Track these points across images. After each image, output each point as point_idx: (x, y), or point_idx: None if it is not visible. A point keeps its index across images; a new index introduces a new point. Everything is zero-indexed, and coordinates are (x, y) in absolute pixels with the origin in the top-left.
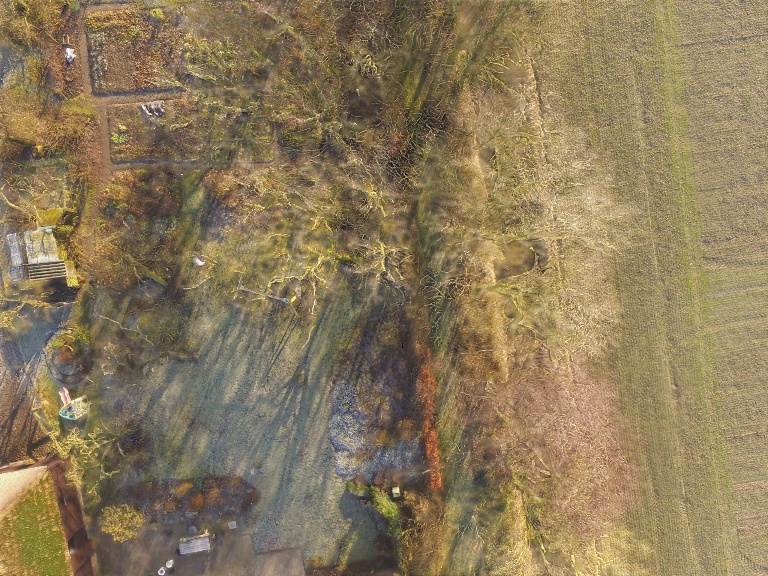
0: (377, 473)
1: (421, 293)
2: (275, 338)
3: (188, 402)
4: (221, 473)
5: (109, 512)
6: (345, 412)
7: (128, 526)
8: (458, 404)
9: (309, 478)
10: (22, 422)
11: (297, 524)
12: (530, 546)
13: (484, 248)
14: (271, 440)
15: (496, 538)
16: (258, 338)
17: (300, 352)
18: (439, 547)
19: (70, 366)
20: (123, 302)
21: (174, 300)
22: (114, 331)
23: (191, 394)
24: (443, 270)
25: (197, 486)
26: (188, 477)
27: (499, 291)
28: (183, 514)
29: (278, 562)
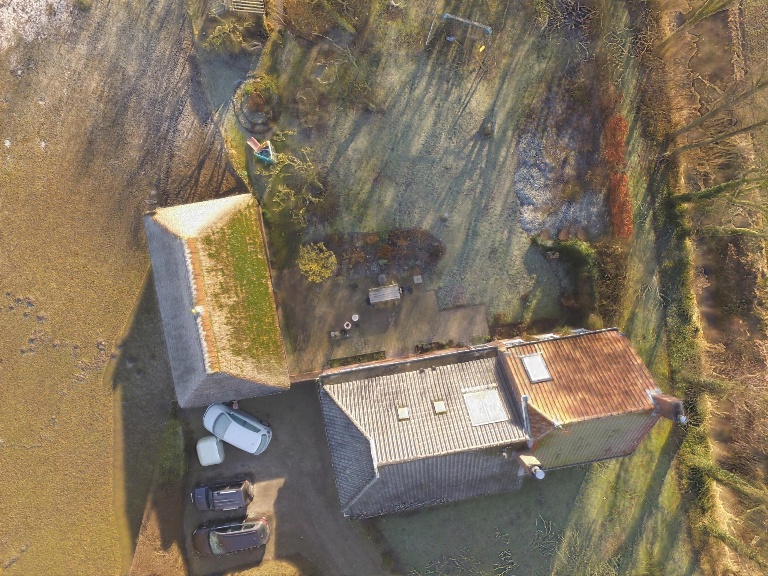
0: (562, 229)
1: (604, 50)
2: (462, 90)
3: (374, 155)
4: (407, 226)
5: (307, 249)
6: (532, 164)
7: (324, 266)
8: (640, 162)
9: (494, 233)
10: (209, 172)
11: (482, 280)
12: (700, 322)
13: (668, 4)
14: (457, 193)
15: (677, 300)
16: (445, 90)
17: (486, 105)
18: (621, 307)
19: (260, 113)
20: (311, 52)
21: (362, 50)
22: (302, 81)
23: (377, 147)
24: (626, 27)
25: (383, 239)
26: (374, 231)
27: (712, 8)
28: (368, 268)
29: (462, 319)
